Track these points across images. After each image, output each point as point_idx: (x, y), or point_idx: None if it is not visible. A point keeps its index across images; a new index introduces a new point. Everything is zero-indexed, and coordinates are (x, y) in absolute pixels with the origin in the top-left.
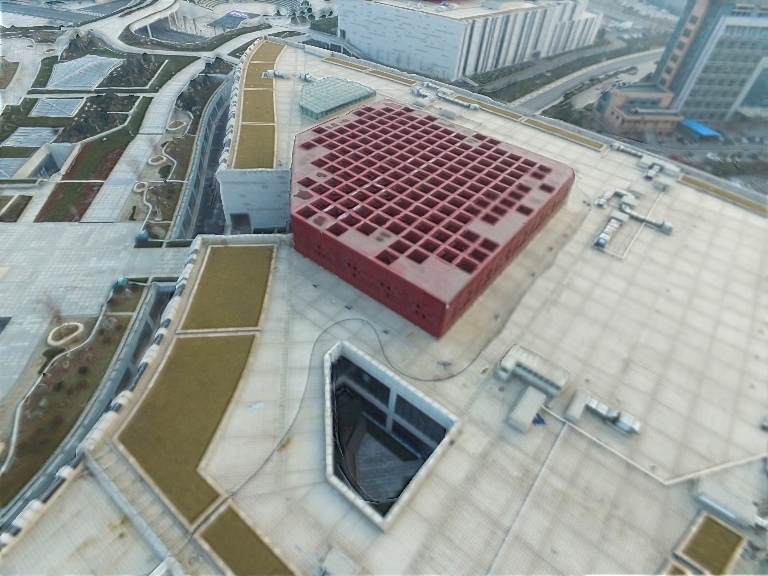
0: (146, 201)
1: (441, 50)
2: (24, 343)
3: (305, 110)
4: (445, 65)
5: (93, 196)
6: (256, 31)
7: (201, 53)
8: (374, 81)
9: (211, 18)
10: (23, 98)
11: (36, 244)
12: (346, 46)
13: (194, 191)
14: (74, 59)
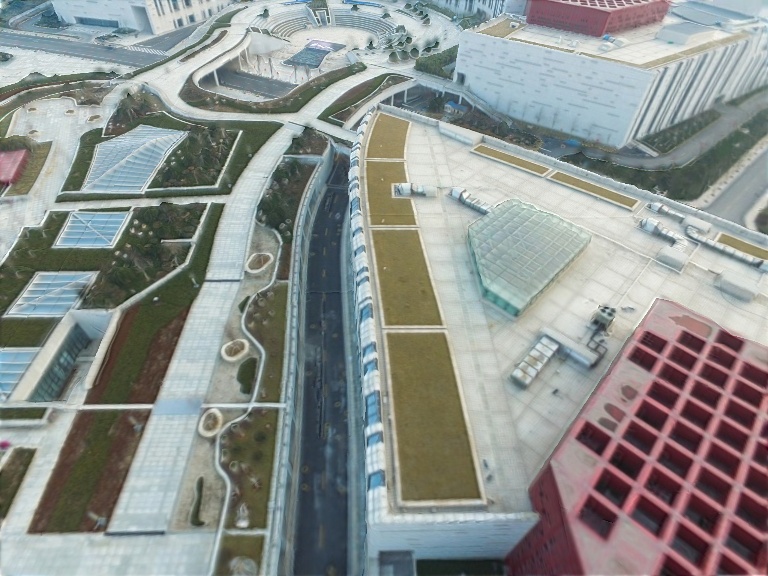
0: (220, 466)
1: (609, 107)
2: None
3: (492, 295)
4: (611, 127)
5: (133, 448)
6: (349, 76)
7: (283, 116)
8: (566, 198)
9: (288, 52)
10: (48, 212)
11: None
12: (467, 96)
13: (294, 413)
14: (122, 133)
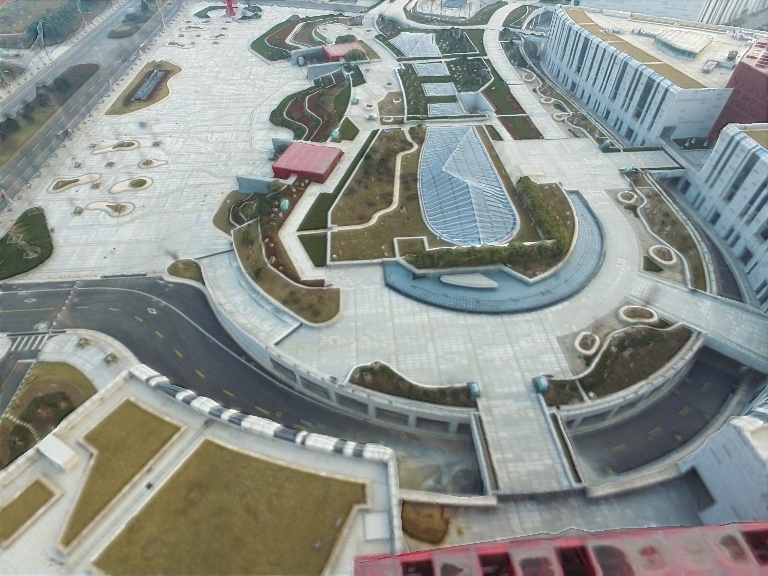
0: (574, 125)
1: (683, 10)
2: (606, 203)
3: (681, 52)
4: None
5: (532, 124)
6: (502, 7)
7: (480, 26)
8: None
9: (438, 1)
10: (402, 64)
11: (535, 152)
12: None
13: None
14: (397, 36)
